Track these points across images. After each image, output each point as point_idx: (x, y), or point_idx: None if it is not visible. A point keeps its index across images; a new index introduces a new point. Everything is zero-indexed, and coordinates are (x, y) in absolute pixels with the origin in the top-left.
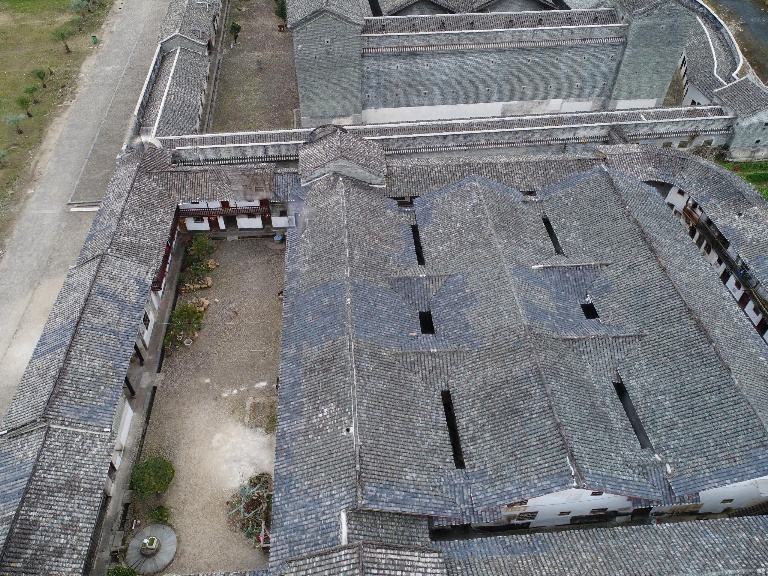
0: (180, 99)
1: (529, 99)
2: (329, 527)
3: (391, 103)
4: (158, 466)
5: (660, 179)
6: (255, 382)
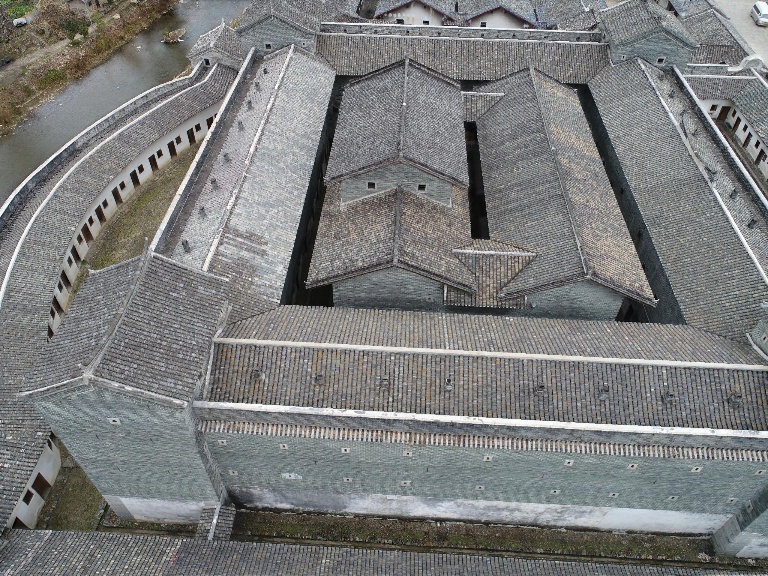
0: None
1: None
2: None
3: None
4: None
5: None
6: None
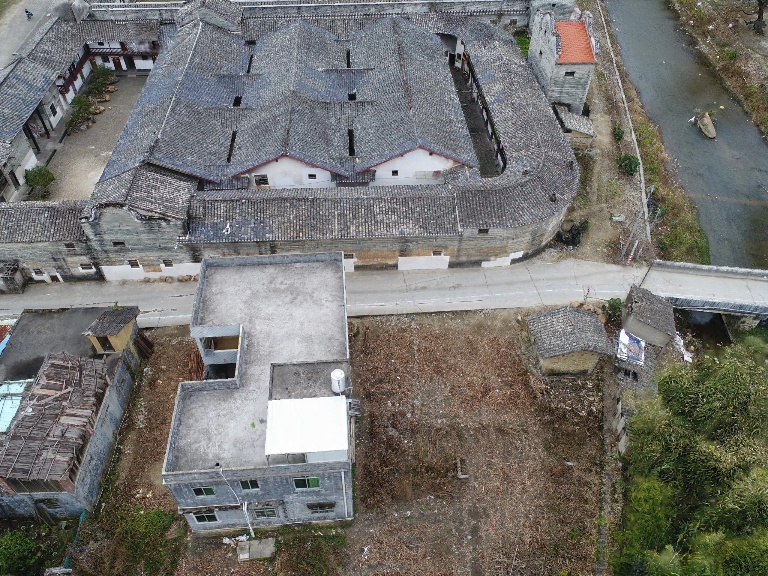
0: None
1: None
2: None
3: None
4: (41, 169)
5: (446, 32)
6: None
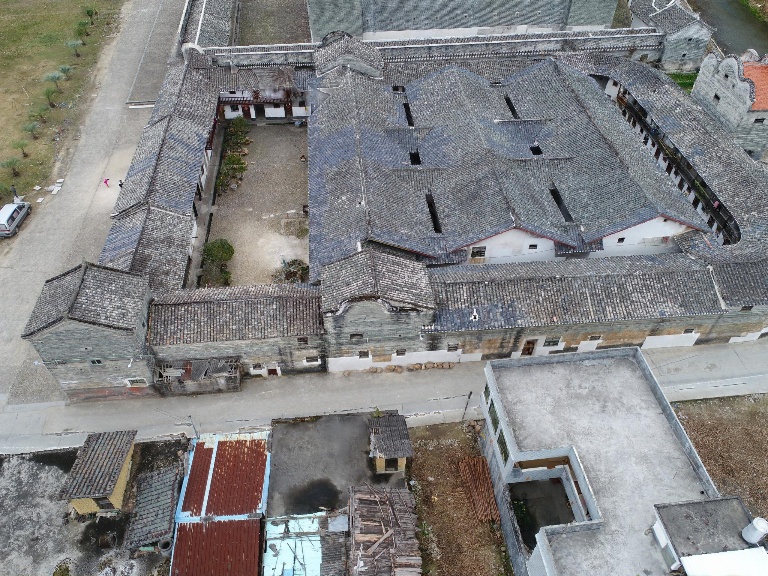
0: (213, 24)
1: (500, 25)
2: (349, 251)
3: (386, 27)
4: (224, 242)
5: (598, 73)
6: (287, 210)
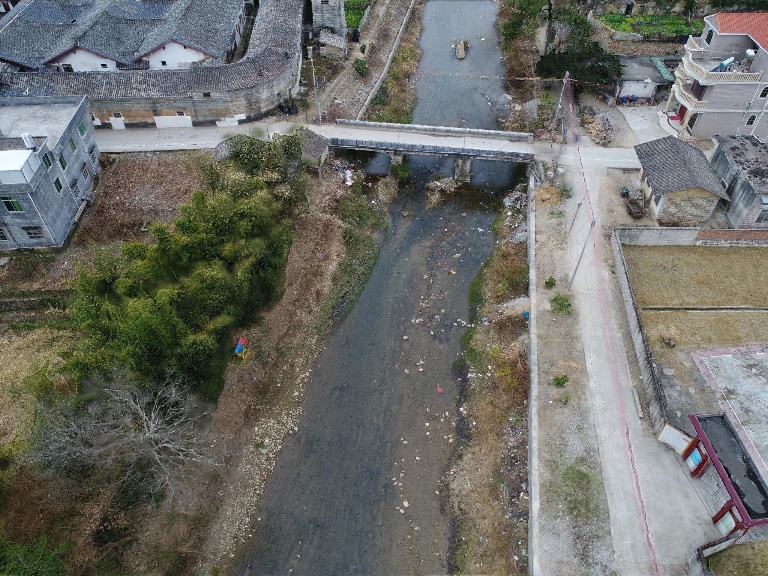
0: None
1: None
2: None
3: None
4: None
5: None
6: None
